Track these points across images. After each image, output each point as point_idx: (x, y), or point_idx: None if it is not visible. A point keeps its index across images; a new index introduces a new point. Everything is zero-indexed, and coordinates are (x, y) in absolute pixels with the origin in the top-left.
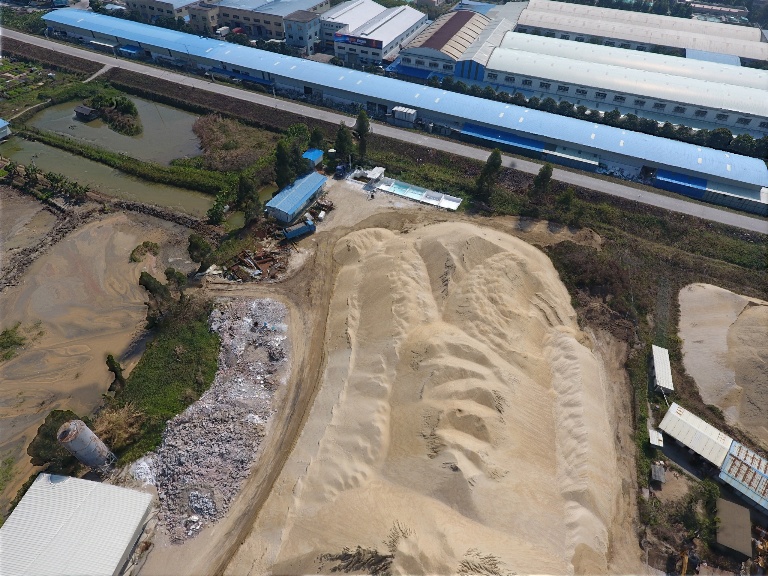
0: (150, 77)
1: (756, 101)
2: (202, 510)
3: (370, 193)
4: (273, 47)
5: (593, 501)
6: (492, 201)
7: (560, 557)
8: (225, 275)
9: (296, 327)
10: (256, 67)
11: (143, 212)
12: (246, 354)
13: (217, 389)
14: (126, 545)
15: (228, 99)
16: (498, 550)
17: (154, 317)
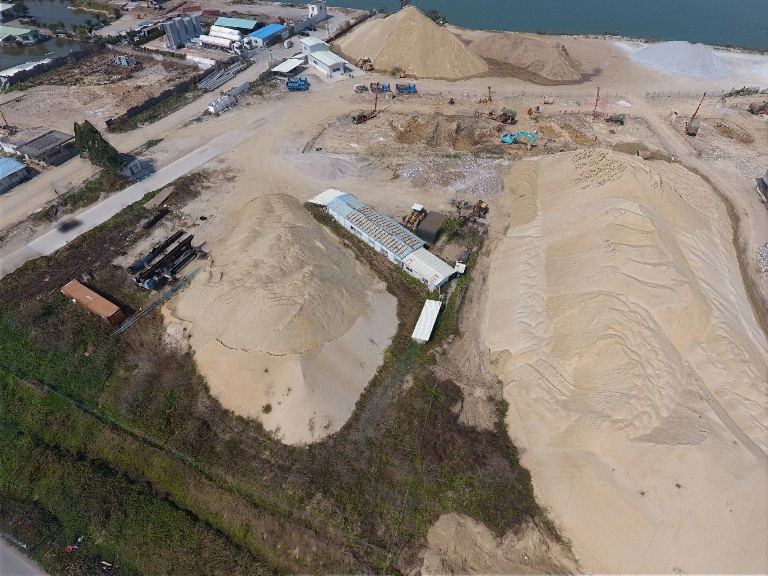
0: None
1: None
2: None
3: None
4: None
5: None
6: None
7: None
8: None
9: None
10: None
11: None
12: None
13: None
14: None
15: None
16: None
17: None
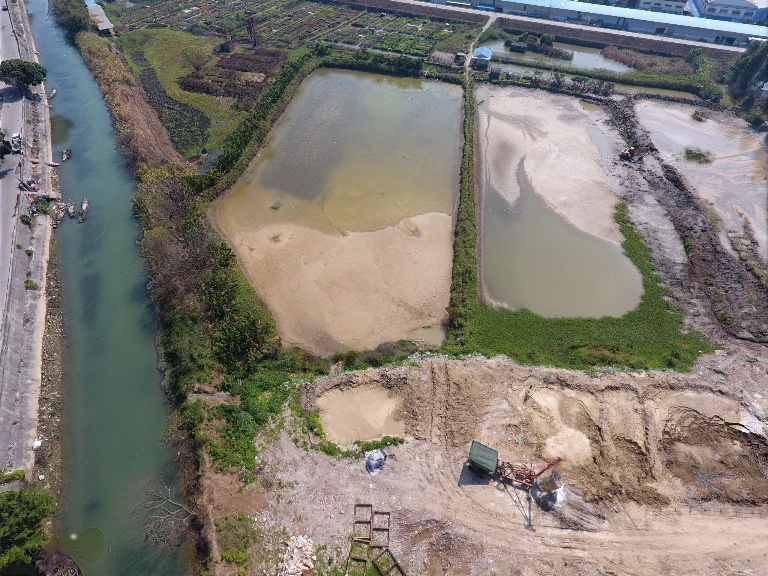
0: (537, 23)
1: None
2: None
3: None
4: (597, 3)
5: None
6: None
7: None
8: None
9: None
10: (615, 14)
11: (660, 99)
12: None
13: None
14: None
15: (616, 36)
16: None
17: None
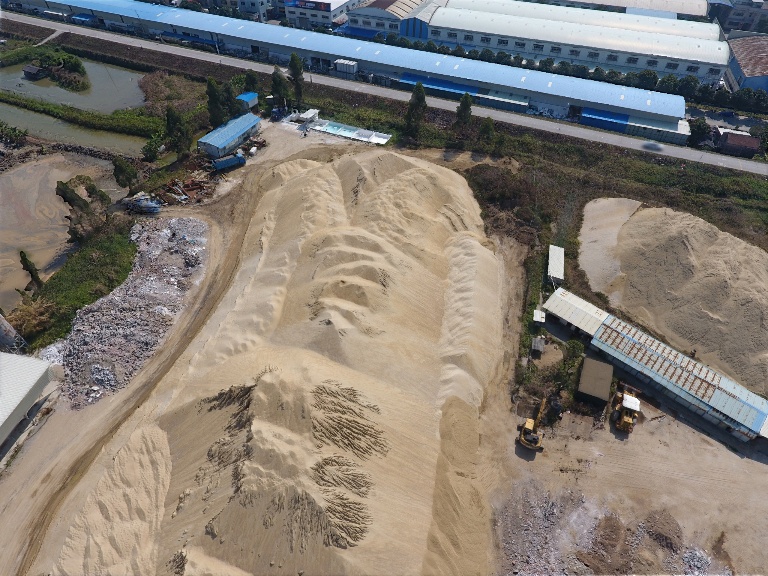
0: (100, 40)
1: (683, 46)
2: (103, 381)
3: (303, 132)
4: (225, 13)
5: (471, 364)
6: (419, 135)
7: (430, 405)
8: (152, 200)
9: (215, 240)
10: (204, 28)
11: (80, 153)
12: (160, 258)
13: (128, 285)
14: (21, 399)
15: (175, 57)
16: (361, 387)
17: (76, 231)
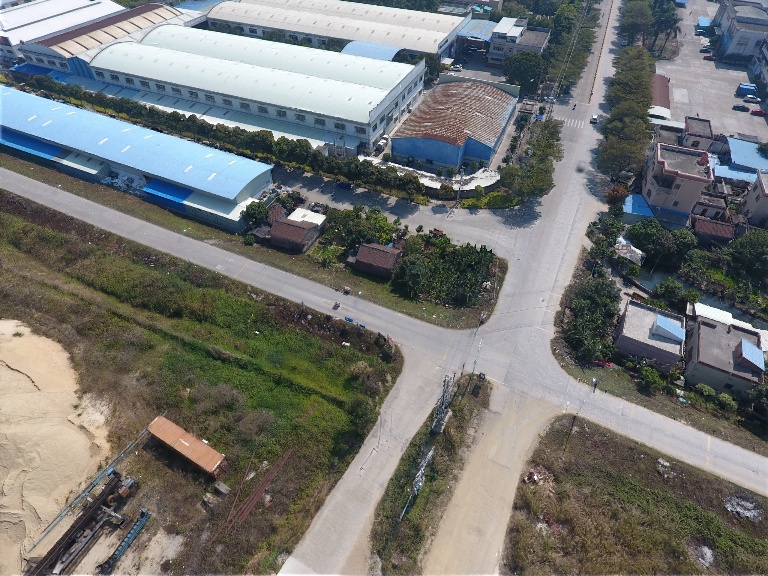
0: None
1: (333, 99)
2: None
3: None
4: None
5: None
6: None
7: None
8: None
9: None
10: None
11: None
12: None
13: None
14: None
15: None
16: None
17: None
